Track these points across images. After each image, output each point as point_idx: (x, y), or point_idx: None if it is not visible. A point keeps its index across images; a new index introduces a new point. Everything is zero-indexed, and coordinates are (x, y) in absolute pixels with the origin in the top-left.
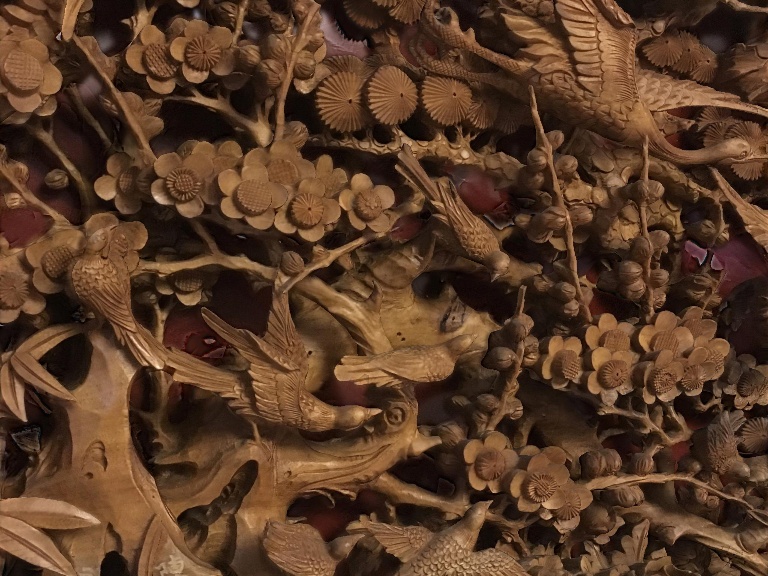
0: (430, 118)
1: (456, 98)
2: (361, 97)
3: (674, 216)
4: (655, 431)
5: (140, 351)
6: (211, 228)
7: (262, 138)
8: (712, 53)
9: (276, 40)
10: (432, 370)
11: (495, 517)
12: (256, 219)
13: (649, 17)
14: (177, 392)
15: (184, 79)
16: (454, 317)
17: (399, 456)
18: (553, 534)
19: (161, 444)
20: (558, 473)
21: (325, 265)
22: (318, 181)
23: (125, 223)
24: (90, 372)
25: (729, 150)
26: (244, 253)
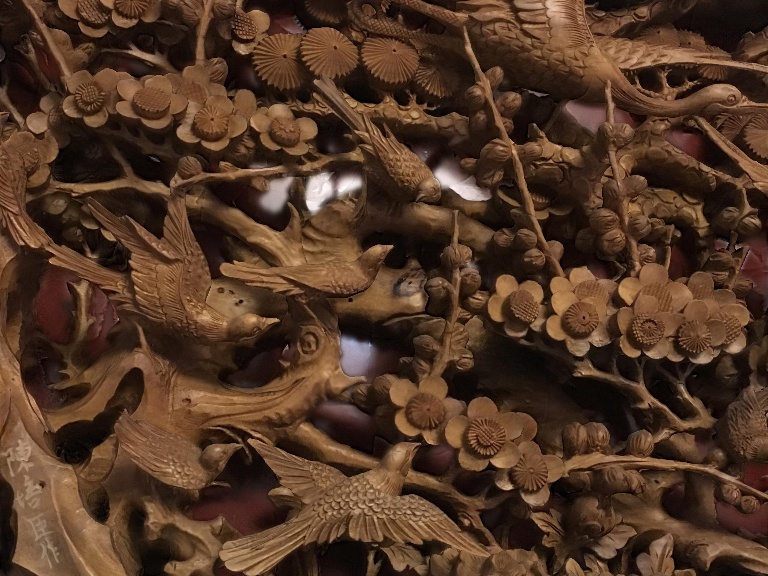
0: (371, 75)
1: (396, 54)
2: (297, 54)
3: (693, 209)
4: (657, 407)
5: (18, 230)
6: (126, 151)
7: None
8: (724, 52)
9: None
10: (337, 278)
11: (442, 486)
12: (153, 122)
13: (631, 6)
14: (97, 331)
15: (113, 24)
16: (411, 282)
17: (316, 393)
18: (534, 533)
19: (68, 375)
20: (509, 424)
21: (230, 177)
22: (226, 98)
23: (41, 140)
24: None
25: (712, 94)
26: (161, 180)
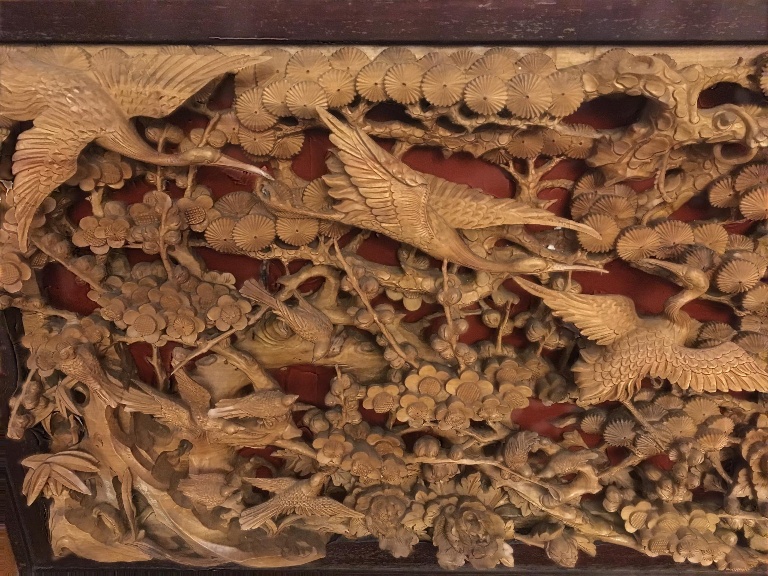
0: (286, 243)
1: (299, 233)
2: None
3: None
4: (469, 435)
5: None
6: None
7: (180, 259)
8: (590, 132)
9: (144, 233)
10: (270, 413)
11: None
12: (150, 336)
13: (498, 128)
14: (168, 382)
15: (110, 246)
16: (334, 348)
17: (277, 438)
18: None
19: None
20: (375, 462)
21: (203, 352)
22: (188, 310)
23: (98, 323)
24: (90, 400)
25: (521, 269)
26: None
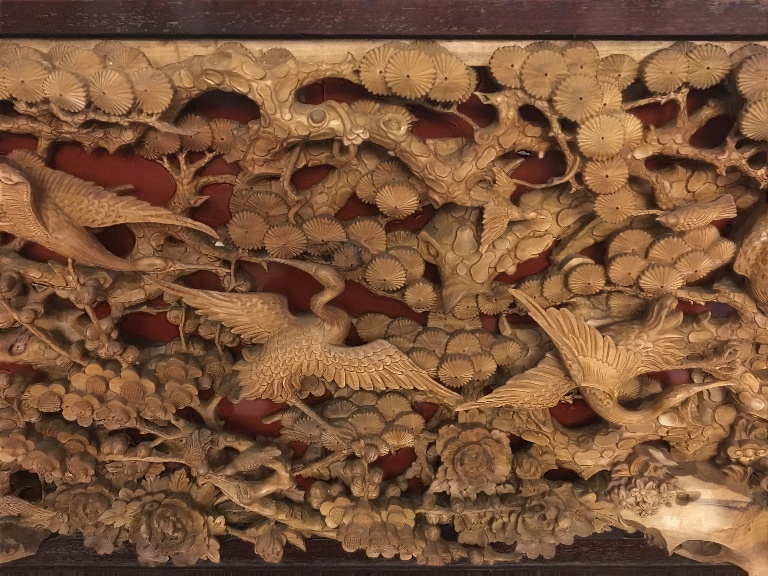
0: None
1: None
2: None
3: None
4: None
5: None
6: None
7: None
8: (232, 127)
9: None
10: None
11: None
12: None
13: None
14: None
15: None
16: (18, 346)
17: None
18: None
19: None
20: None
21: None
22: None
23: None
24: None
25: (141, 268)
26: None
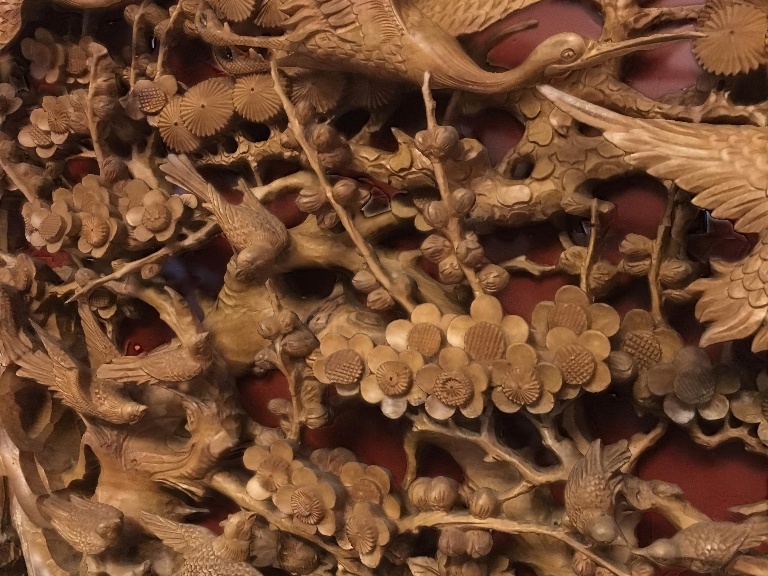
0: None
1: (255, 93)
2: None
3: None
4: (504, 460)
5: None
6: None
7: (136, 173)
8: None
9: (70, 96)
10: (172, 369)
11: (310, 537)
12: (55, 245)
13: None
14: None
15: (54, 143)
16: (319, 318)
17: (205, 456)
18: None
19: None
20: (328, 493)
21: (115, 277)
22: (103, 205)
23: None
24: None
25: (541, 55)
26: (103, 272)
